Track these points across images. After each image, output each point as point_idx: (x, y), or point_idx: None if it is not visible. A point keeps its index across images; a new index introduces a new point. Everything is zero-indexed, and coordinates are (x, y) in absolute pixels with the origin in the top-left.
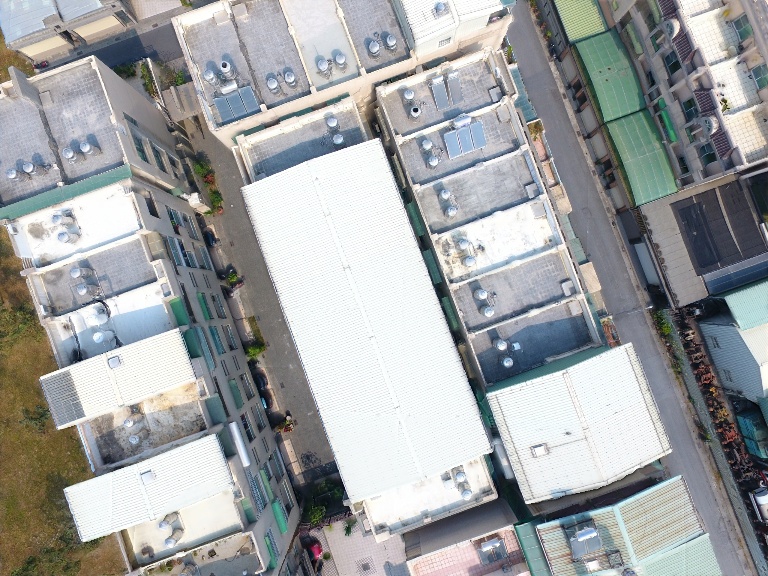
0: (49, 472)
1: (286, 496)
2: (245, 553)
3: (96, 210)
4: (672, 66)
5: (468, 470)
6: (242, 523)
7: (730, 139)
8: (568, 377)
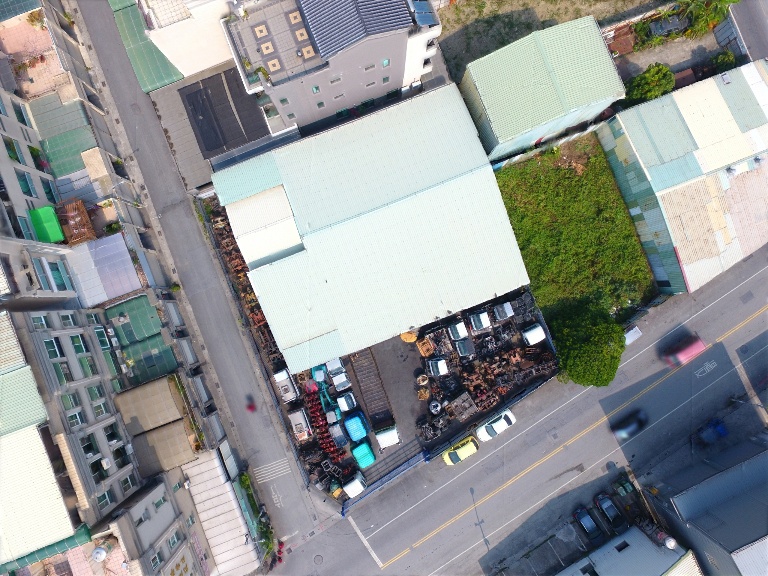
0: None
1: None
2: None
3: None
4: None
5: None
6: None
7: (142, 4)
8: None
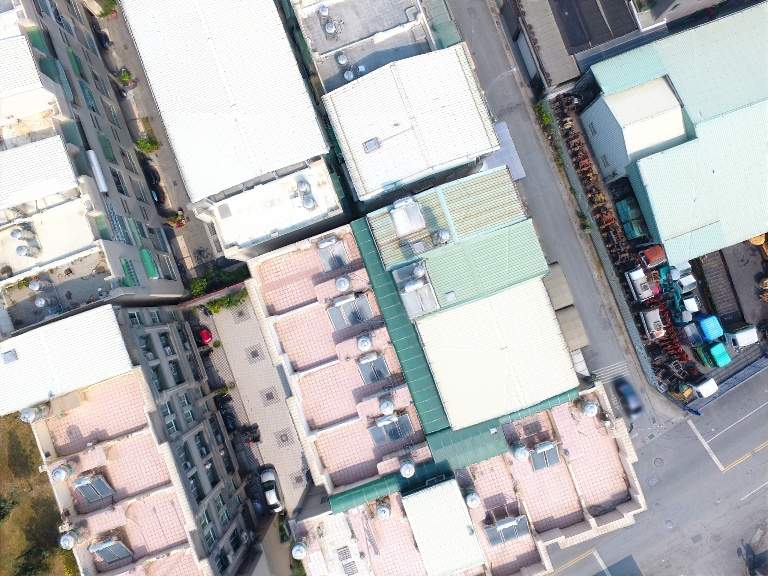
0: None
1: (167, 268)
2: (100, 272)
3: None
4: None
5: (316, 191)
6: (93, 235)
7: None
8: (395, 69)
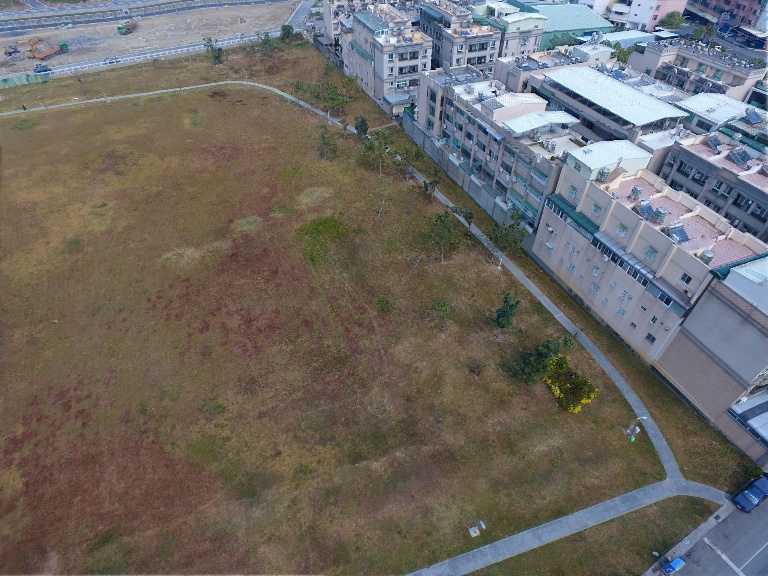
0: (413, 230)
1: None
2: None
3: None
4: (680, 86)
5: None
6: None
7: (719, 83)
8: None
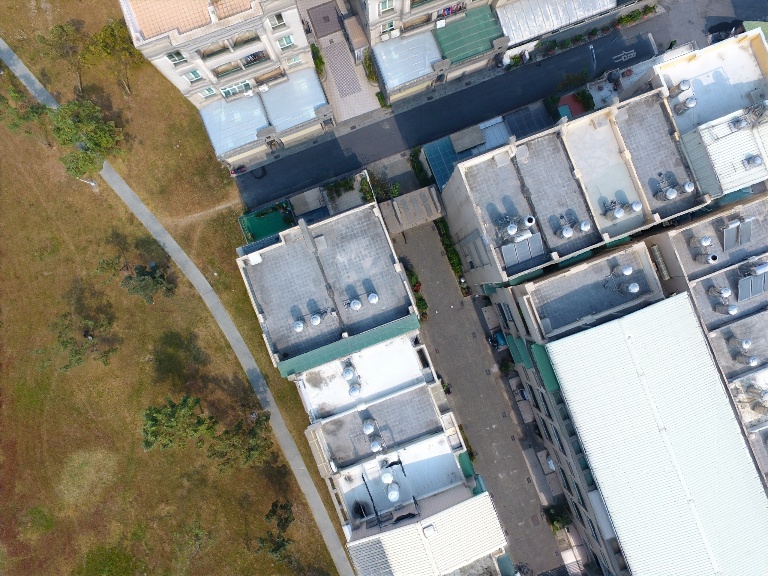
0: None
1: None
2: None
3: (375, 358)
4: None
5: None
6: None
7: None
8: None
